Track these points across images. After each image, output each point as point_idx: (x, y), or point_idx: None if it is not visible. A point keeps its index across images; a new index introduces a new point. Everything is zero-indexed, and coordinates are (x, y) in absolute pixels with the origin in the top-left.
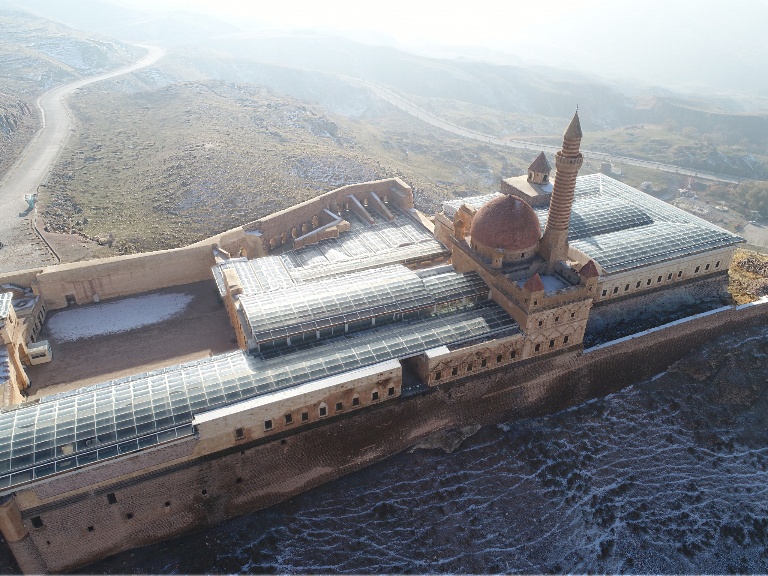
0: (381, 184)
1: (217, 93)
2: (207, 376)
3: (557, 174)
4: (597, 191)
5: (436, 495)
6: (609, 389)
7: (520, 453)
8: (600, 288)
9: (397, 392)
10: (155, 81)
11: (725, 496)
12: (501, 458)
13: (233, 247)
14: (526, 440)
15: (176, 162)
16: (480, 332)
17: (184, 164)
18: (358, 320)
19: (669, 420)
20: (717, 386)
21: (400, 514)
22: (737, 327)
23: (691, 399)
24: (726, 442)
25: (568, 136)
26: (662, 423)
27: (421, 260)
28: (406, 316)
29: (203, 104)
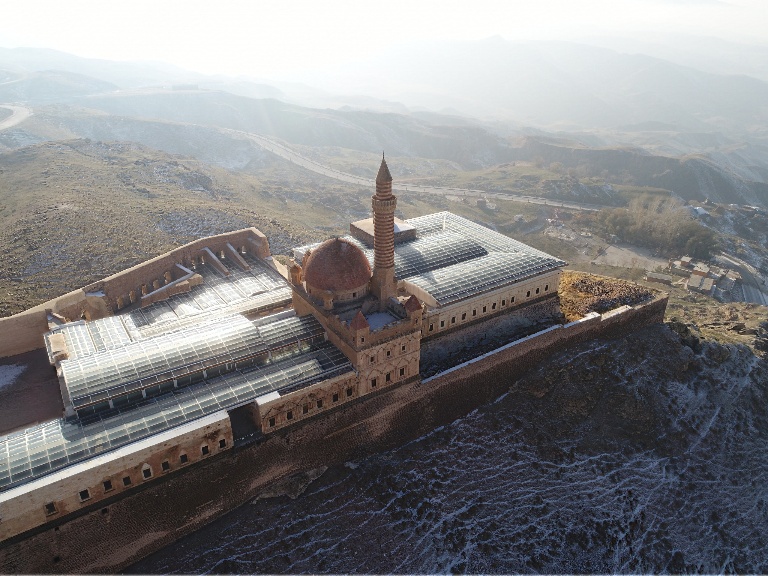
0: (237, 235)
1: (81, 152)
2: (14, 451)
3: (375, 216)
4: (440, 228)
5: (281, 544)
6: (455, 415)
7: (368, 489)
8: (437, 319)
9: (229, 443)
10: (18, 142)
11: (569, 504)
12: (349, 497)
13: (73, 310)
14: (374, 475)
15: (24, 226)
16: (313, 374)
17: (33, 227)
18: (187, 374)
19: (513, 438)
20: (555, 401)
21: (243, 570)
22: (569, 344)
23: (532, 416)
24: (567, 453)
25: (378, 180)
26: (507, 442)
27: (274, 307)
28: (240, 365)
29: (63, 164)
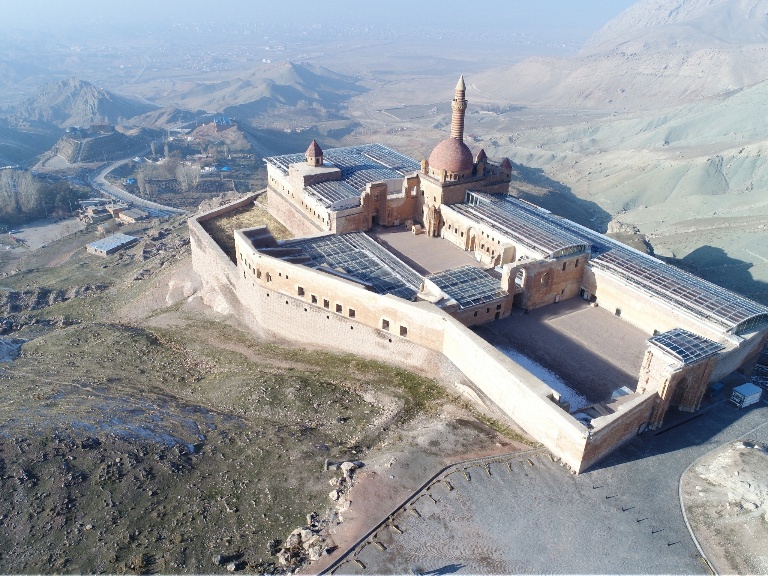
0: None
1: None
2: None
3: (461, 113)
4: None
5: None
6: None
7: None
8: None
9: None
10: None
11: None
12: None
13: None
14: None
15: None
16: None
17: None
18: None
19: None
20: None
21: None
22: None
23: None
24: None
25: None
26: None
27: None
28: None
29: None
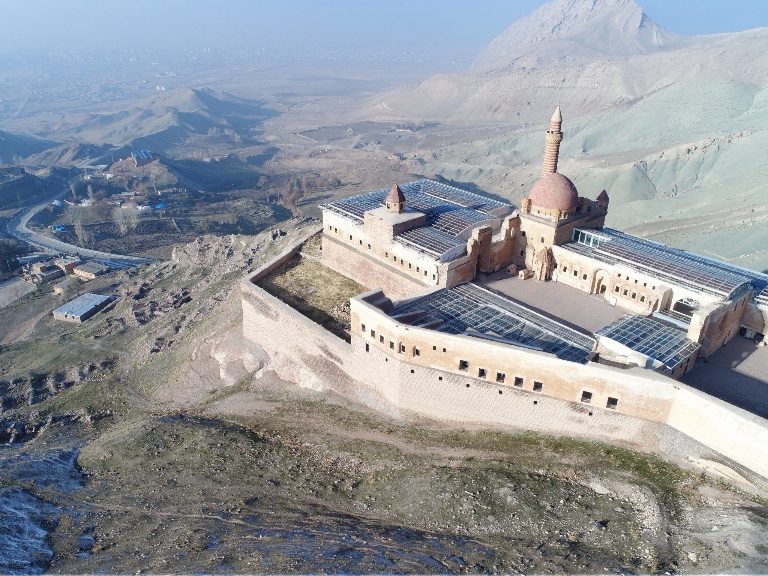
0: None
1: None
2: None
3: None
4: (374, 204)
5: None
6: None
7: None
8: None
9: None
10: None
11: None
12: None
13: None
14: None
15: None
16: None
17: None
18: None
19: None
20: None
21: None
22: None
23: None
24: None
25: None
26: None
27: None
28: None
29: None
